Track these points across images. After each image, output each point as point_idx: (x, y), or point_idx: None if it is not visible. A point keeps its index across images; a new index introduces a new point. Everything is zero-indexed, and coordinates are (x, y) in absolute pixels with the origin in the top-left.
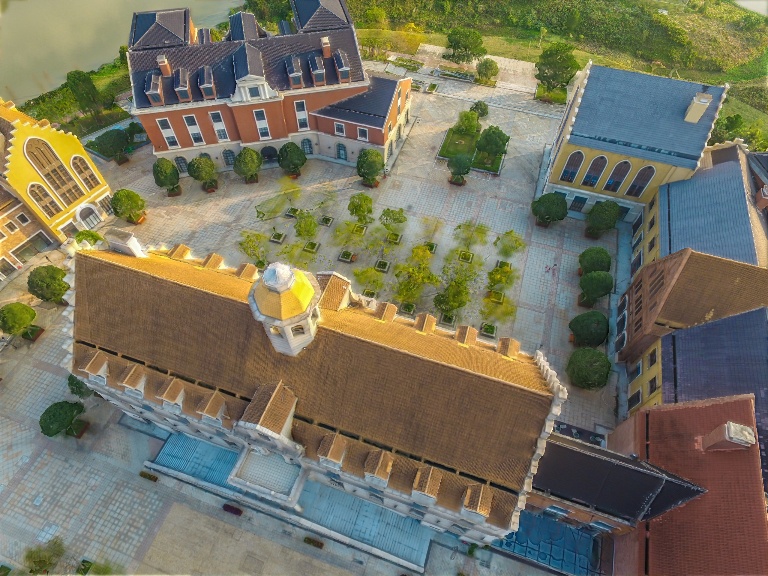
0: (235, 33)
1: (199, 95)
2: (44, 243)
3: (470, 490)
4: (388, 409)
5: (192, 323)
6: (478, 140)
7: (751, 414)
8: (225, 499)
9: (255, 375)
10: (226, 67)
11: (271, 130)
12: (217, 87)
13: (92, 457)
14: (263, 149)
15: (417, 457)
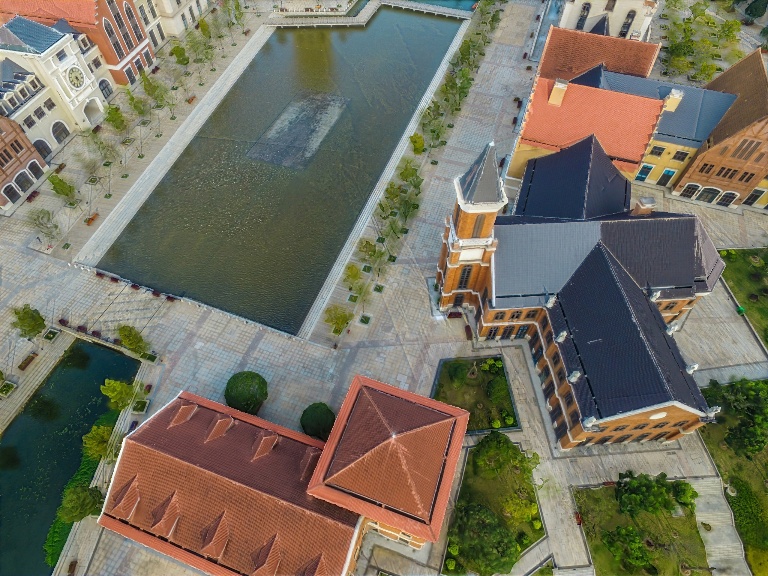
0: None
1: None
2: None
3: None
4: None
5: None
6: None
7: None
8: None
9: None
10: None
11: None
12: None
13: None
14: None
15: None
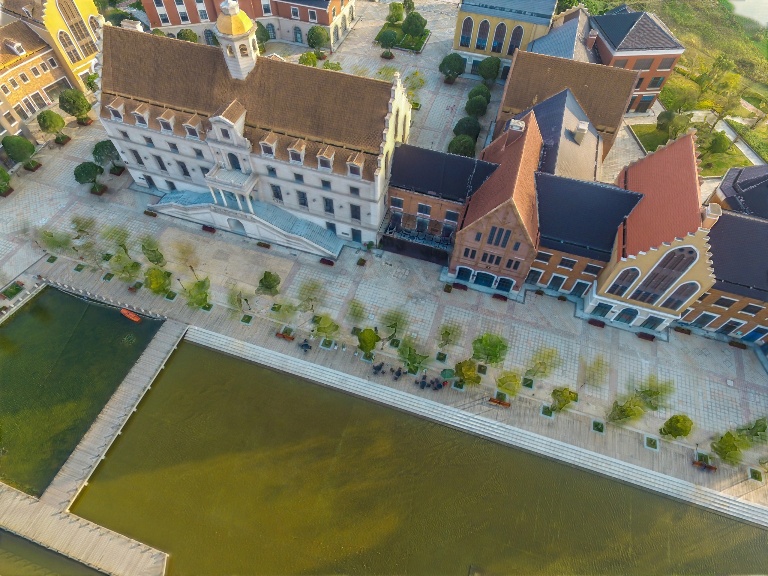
0: None
1: None
2: None
3: None
4: (301, 109)
5: (180, 66)
6: None
7: (529, 119)
8: None
9: (220, 98)
10: None
11: None
12: None
13: (110, 205)
14: None
15: (320, 141)
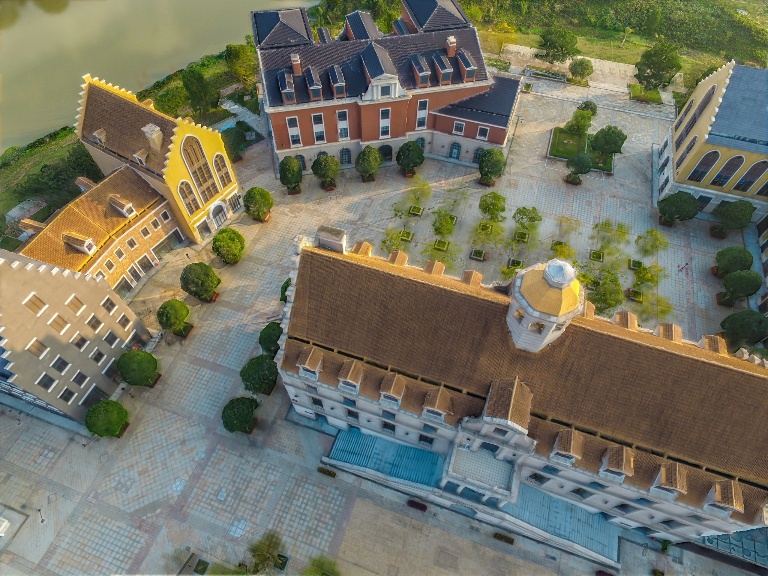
0: (357, 32)
1: (329, 94)
2: (177, 240)
3: (719, 486)
4: (634, 405)
5: (424, 319)
6: (587, 139)
7: None
8: (407, 495)
9: (488, 371)
10: (354, 66)
11: (392, 129)
12: (346, 86)
13: (266, 453)
14: (380, 148)
15: (659, 453)
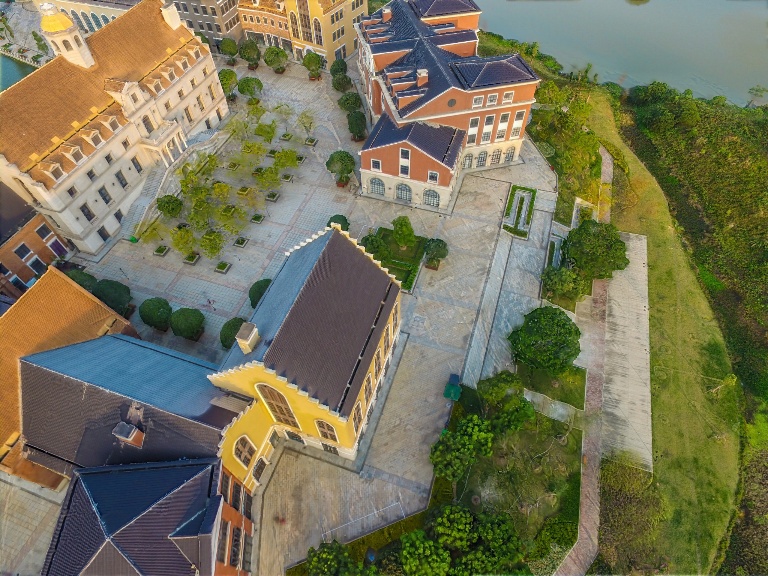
0: None
1: None
2: None
3: None
4: None
5: None
6: None
7: None
8: None
9: None
10: None
11: None
12: None
13: None
14: None
15: None
